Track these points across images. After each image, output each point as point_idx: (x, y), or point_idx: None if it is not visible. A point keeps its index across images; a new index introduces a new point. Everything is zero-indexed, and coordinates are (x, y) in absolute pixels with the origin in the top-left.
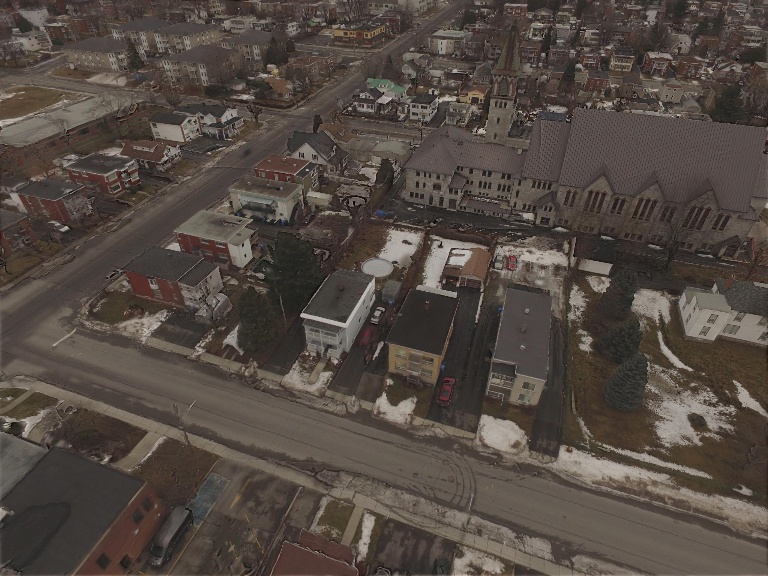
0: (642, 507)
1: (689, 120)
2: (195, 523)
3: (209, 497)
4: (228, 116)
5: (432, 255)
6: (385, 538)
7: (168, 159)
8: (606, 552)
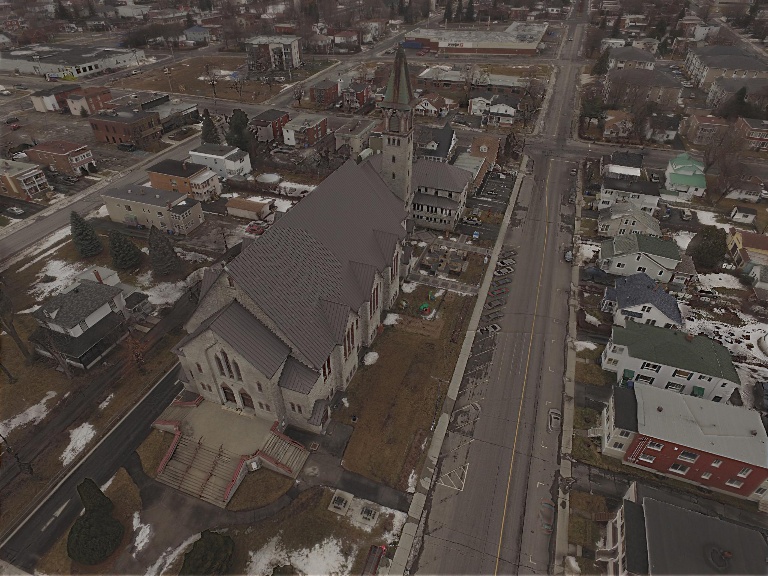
0: (31, 243)
1: (287, 214)
2: (130, 152)
3: (138, 153)
4: (502, 110)
5: (282, 200)
6: (89, 182)
7: (422, 109)
8: (27, 228)
